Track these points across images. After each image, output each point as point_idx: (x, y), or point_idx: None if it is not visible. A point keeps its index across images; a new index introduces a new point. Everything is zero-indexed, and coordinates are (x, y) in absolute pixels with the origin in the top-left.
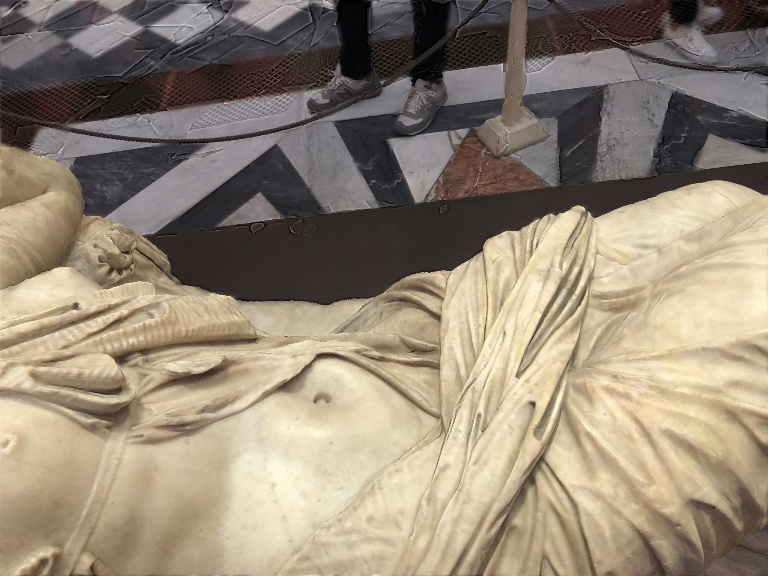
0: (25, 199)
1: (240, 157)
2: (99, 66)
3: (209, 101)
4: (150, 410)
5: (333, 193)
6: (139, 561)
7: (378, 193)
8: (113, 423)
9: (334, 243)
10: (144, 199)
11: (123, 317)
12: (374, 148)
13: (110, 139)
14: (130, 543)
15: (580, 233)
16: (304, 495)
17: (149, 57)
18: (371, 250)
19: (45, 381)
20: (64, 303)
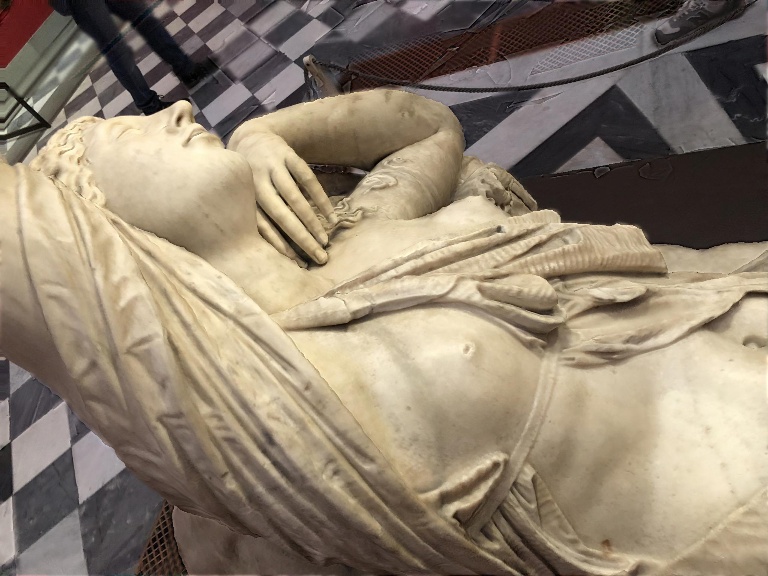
0: (421, 139)
1: (575, 101)
2: (445, 21)
3: (550, 43)
4: (577, 335)
5: (685, 132)
6: (570, 483)
7: (745, 128)
8: (547, 343)
9: (696, 185)
10: (477, 151)
11: (542, 242)
12: (737, 77)
13: (453, 92)
14: (563, 463)
15: None
16: (746, 445)
17: (497, 3)
18: (744, 191)
19: (489, 296)
20: None
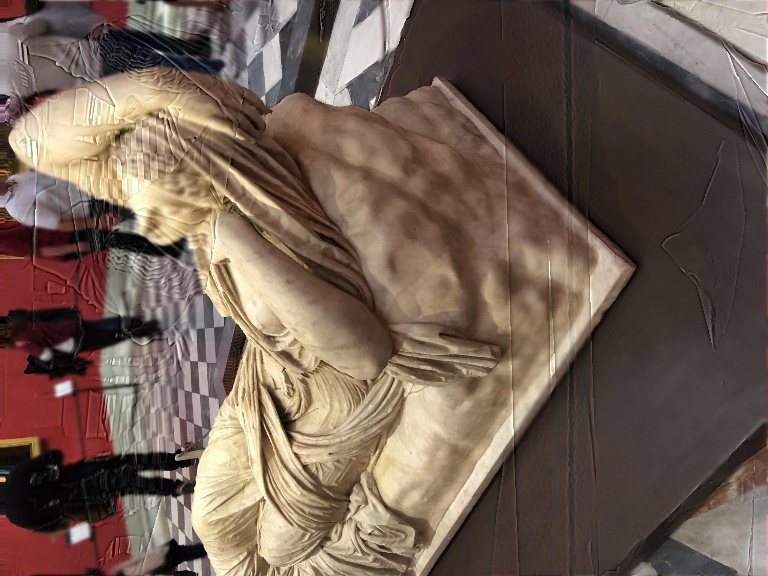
0: None
1: None
2: None
3: None
4: None
5: None
6: None
7: None
8: None
9: None
10: None
11: None
12: None
13: None
14: None
15: None
16: None
17: None
18: None
19: None
20: (235, 317)
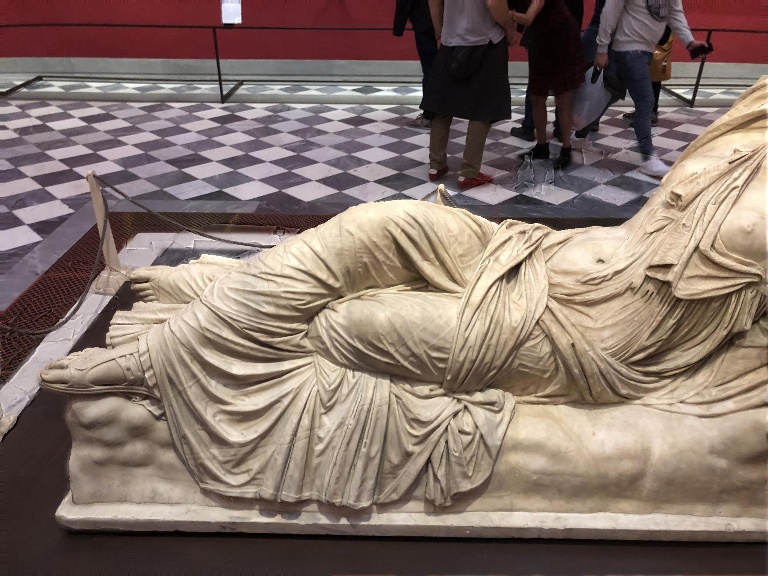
0: None
1: None
2: None
3: None
4: None
5: None
6: None
7: None
8: None
9: None
10: None
11: None
12: None
13: None
14: None
15: None
16: None
17: None
18: None
19: None
20: None
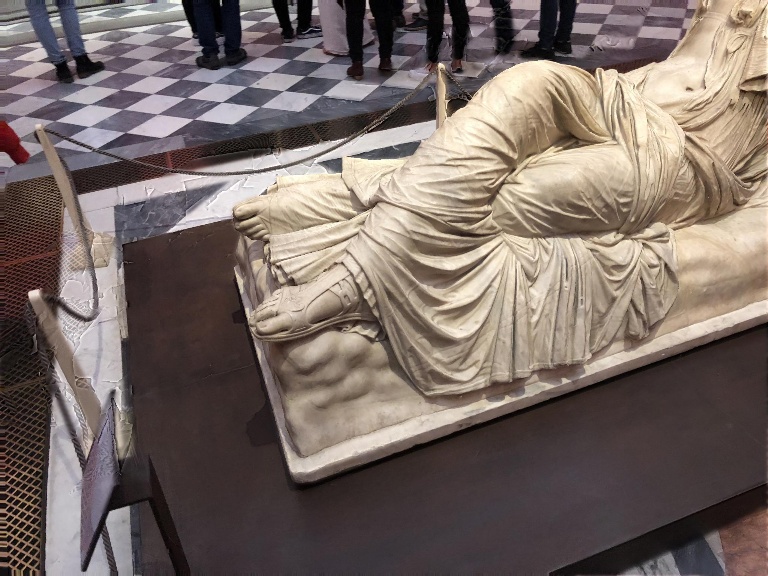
0: None
1: None
2: None
3: None
4: None
5: None
6: None
7: None
8: None
9: None
10: None
11: None
12: None
13: None
14: None
15: None
16: None
17: None
18: None
19: None
20: None
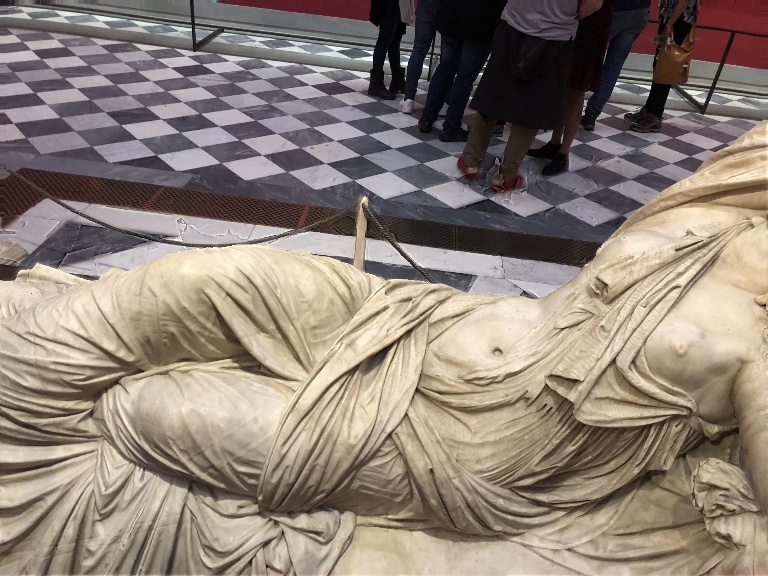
0: None
1: None
2: None
3: None
4: None
5: None
6: None
7: None
8: None
9: None
10: None
11: None
12: None
13: None
14: None
15: (310, 381)
16: None
17: None
18: None
19: None
20: None
